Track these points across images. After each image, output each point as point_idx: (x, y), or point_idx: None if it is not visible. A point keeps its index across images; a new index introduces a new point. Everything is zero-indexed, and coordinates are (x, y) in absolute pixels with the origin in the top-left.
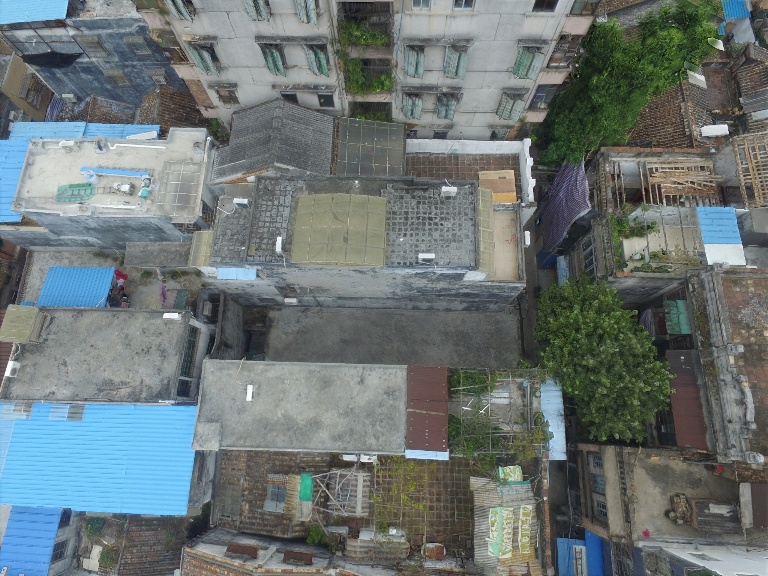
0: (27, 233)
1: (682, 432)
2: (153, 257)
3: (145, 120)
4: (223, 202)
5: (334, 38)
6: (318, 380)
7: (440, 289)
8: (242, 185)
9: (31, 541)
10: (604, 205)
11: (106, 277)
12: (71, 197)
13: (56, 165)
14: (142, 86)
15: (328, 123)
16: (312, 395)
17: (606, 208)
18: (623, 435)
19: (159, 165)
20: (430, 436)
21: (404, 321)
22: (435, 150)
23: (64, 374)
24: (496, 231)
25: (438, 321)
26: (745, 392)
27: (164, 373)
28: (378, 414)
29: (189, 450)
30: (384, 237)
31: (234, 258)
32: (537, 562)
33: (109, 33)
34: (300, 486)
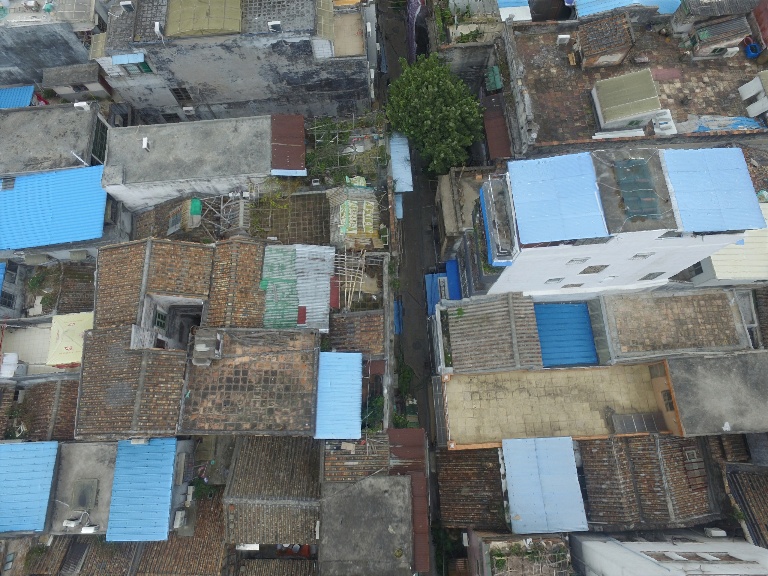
0: None
1: (494, 150)
2: (66, 77)
3: None
4: (113, 10)
5: None
6: (201, 133)
7: (303, 75)
8: None
9: None
10: None
11: (27, 92)
12: None
13: None
14: None
15: None
16: (196, 143)
17: None
18: (449, 158)
19: None
20: (291, 160)
21: None
22: None
23: None
24: (346, 28)
25: None
26: (524, 95)
27: (79, 148)
28: (249, 150)
29: (102, 194)
30: (240, 13)
31: (124, 46)
32: (380, 240)
33: None
34: (191, 206)
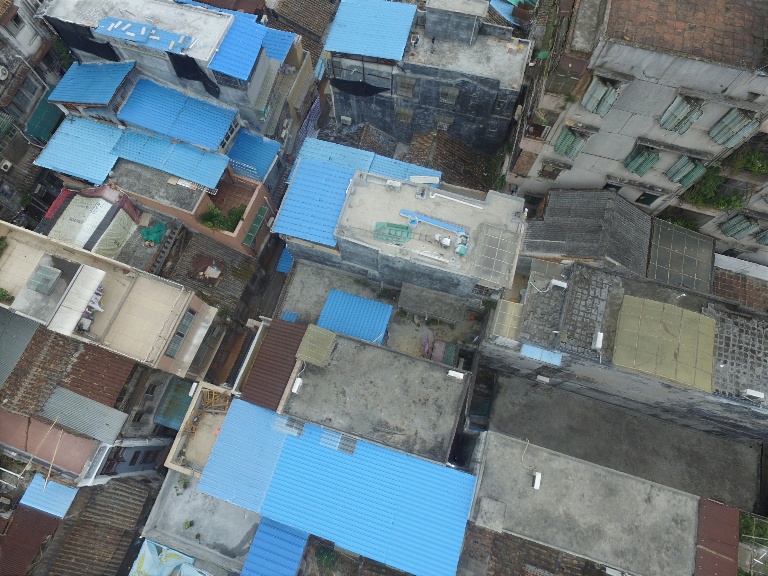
0: (317, 251)
1: None
2: (428, 304)
3: (417, 159)
4: (535, 278)
5: (720, 157)
6: (603, 485)
7: (720, 416)
8: (551, 263)
9: (276, 558)
10: None
11: (384, 314)
12: (389, 236)
13: (376, 200)
14: (420, 126)
15: (647, 222)
16: (596, 500)
17: None
18: None
19: (474, 224)
20: None
21: (636, 424)
22: (724, 266)
23: (342, 403)
24: None
25: (672, 434)
26: None
27: (439, 430)
28: (665, 540)
29: (461, 519)
30: (712, 362)
31: (543, 339)
32: None
33: (430, 80)
34: None
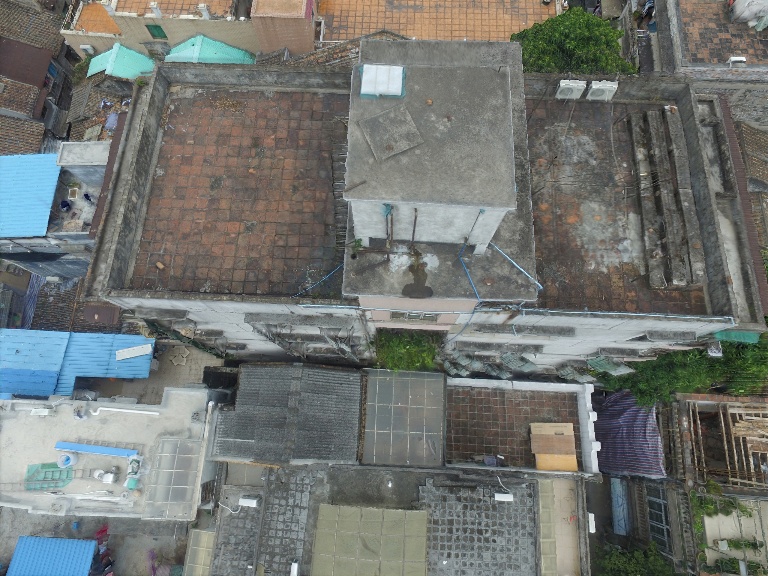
0: None
1: None
2: (142, 523)
3: None
4: (226, 494)
5: (368, 337)
6: None
7: None
8: None
9: None
10: (680, 466)
11: (85, 555)
12: (43, 483)
13: (27, 434)
14: None
15: (354, 384)
16: None
17: (684, 477)
18: None
19: (150, 438)
20: None
21: None
22: (477, 385)
23: None
24: None
25: None
26: None
27: None
28: None
29: None
30: (424, 570)
31: None
32: None
33: None
34: None
